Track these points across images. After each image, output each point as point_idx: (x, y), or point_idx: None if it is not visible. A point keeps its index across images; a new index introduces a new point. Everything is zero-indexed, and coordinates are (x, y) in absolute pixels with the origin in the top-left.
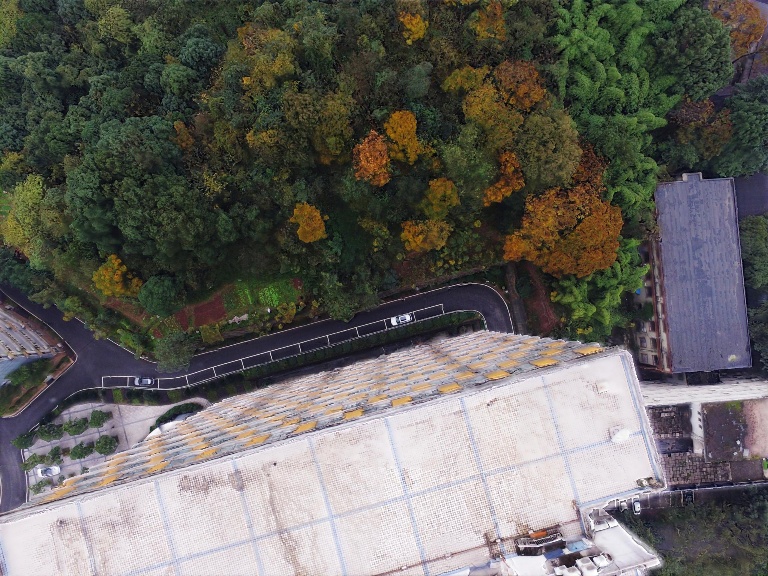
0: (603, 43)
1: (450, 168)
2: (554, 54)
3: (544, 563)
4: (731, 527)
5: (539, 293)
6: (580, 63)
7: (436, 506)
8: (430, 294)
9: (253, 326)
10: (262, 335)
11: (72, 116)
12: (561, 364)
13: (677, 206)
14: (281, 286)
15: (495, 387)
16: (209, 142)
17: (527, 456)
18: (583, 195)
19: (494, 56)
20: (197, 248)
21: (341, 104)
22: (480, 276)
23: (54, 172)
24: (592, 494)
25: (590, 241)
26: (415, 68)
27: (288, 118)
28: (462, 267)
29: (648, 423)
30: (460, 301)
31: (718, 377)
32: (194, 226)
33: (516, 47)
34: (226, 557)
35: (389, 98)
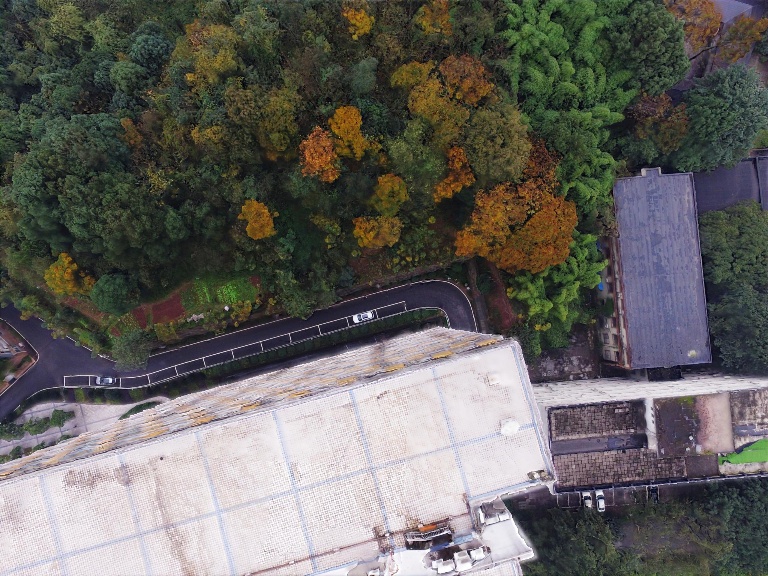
0: (556, 38)
1: (397, 164)
2: (505, 49)
3: (424, 557)
4: (690, 523)
5: (500, 290)
6: (534, 58)
7: (325, 500)
8: (392, 291)
9: (208, 324)
10: (218, 333)
11: (22, 114)
12: (452, 356)
13: (636, 201)
14: (239, 284)
15: (381, 379)
16: (158, 139)
17: (417, 449)
18: (533, 190)
19: (444, 51)
20: (147, 246)
21: (285, 100)
22: (442, 273)
23: (7, 171)
24: (483, 487)
25: (541, 236)
26: None
27: (229, 114)
28: (420, 264)
29: (538, 415)
30: (422, 298)
31: (679, 373)
32: (140, 223)
33: (467, 42)
34: (111, 553)
35: (333, 94)
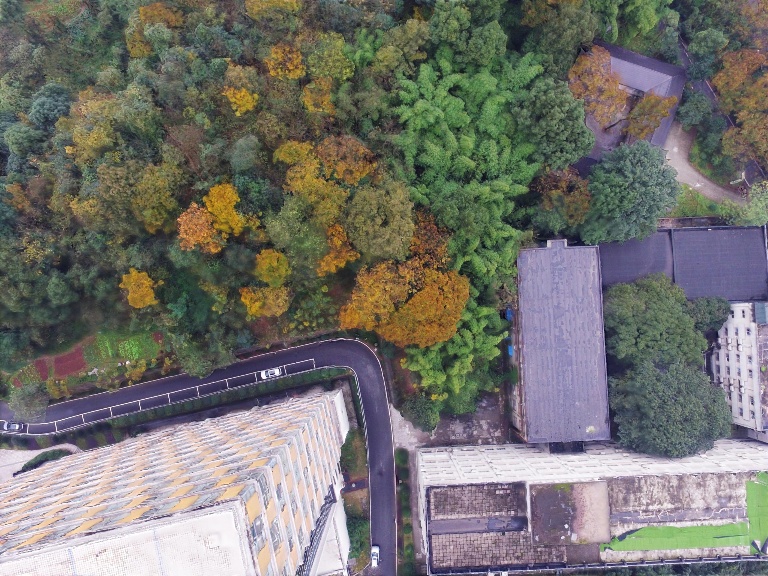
0: (456, 112)
1: (275, 241)
2: (398, 124)
3: None
4: None
5: None
6: (432, 131)
7: None
8: (300, 349)
9: (102, 382)
10: (111, 391)
11: None
12: (174, 516)
13: (540, 273)
14: (141, 339)
15: (91, 543)
16: (48, 203)
17: None
18: (415, 269)
19: (334, 126)
20: (32, 309)
21: (159, 177)
22: (352, 332)
23: None
24: None
25: (422, 316)
26: (237, 142)
27: None
28: (319, 328)
29: None
30: (332, 356)
31: (582, 446)
32: (17, 291)
33: (359, 116)
34: None
35: (208, 172)
